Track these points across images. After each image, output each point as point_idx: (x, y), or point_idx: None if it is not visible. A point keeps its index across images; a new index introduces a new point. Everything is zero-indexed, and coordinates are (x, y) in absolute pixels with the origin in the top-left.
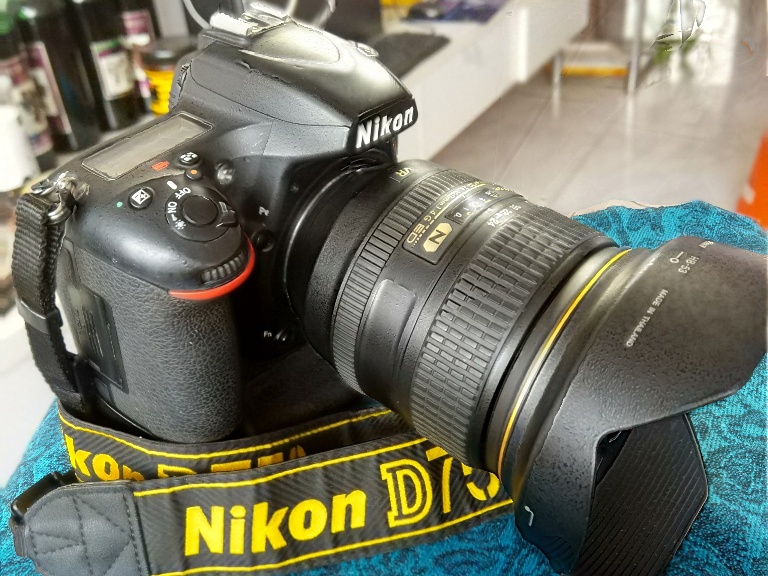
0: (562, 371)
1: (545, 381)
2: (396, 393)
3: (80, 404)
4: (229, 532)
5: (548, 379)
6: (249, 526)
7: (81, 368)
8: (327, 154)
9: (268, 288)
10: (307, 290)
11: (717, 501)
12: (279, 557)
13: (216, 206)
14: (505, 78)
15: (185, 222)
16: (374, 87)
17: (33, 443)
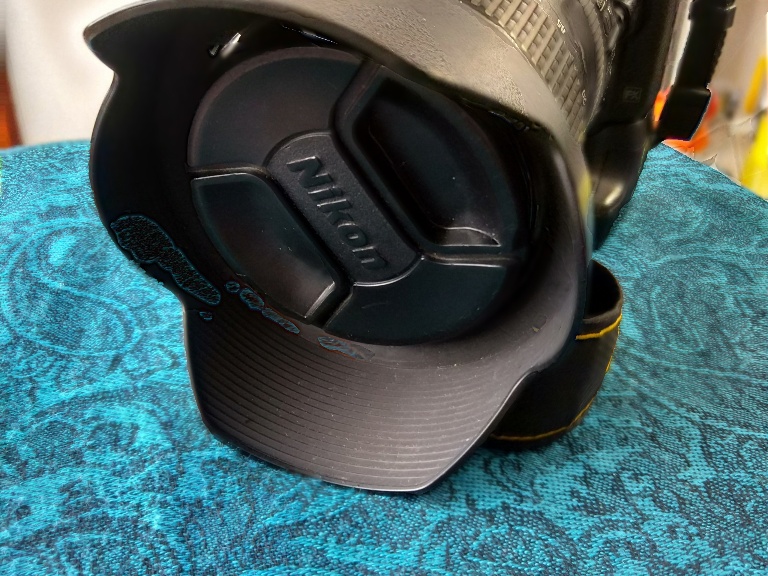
0: None
1: None
2: None
3: None
4: None
5: None
6: None
7: None
8: None
9: None
10: None
11: (431, 516)
12: None
13: None
14: None
15: None
16: None
17: None
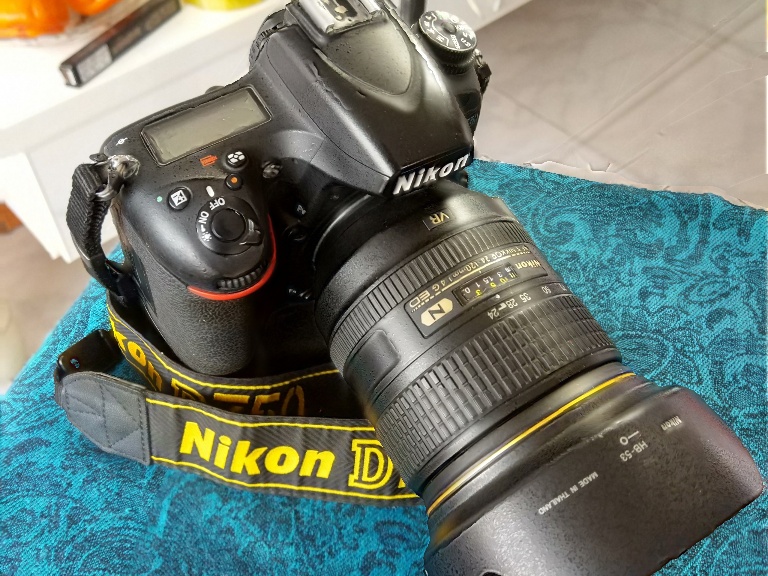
0: (486, 495)
1: (473, 490)
2: (368, 415)
3: (122, 302)
4: (216, 451)
5: (475, 490)
6: (232, 453)
7: (124, 281)
8: (365, 190)
9: (296, 264)
10: (320, 295)
11: None
12: (252, 480)
13: (245, 223)
14: (661, 5)
15: (212, 235)
16: (430, 135)
17: None
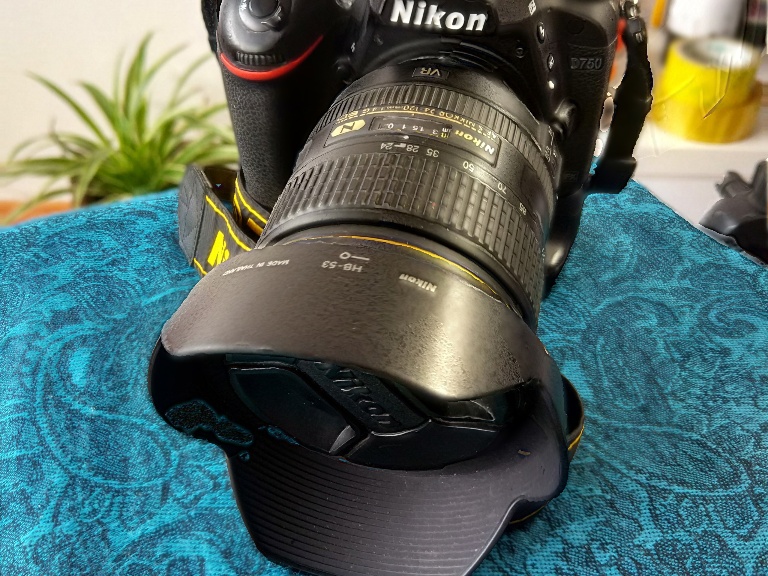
0: None
1: None
2: None
3: None
4: None
5: None
6: None
7: None
8: None
9: None
10: None
11: None
12: None
13: (276, 8)
14: None
15: (247, 6)
16: None
17: None
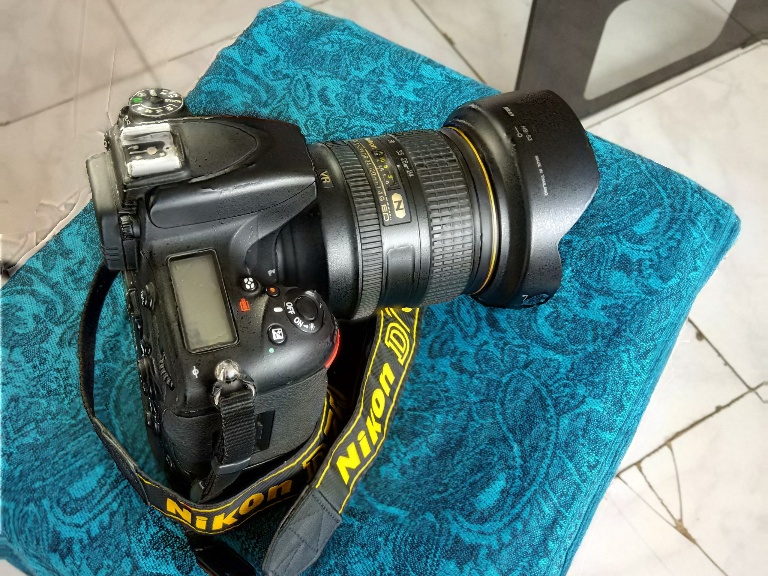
0: (517, 227)
1: (506, 237)
2: None
3: None
4: (360, 450)
5: (508, 235)
6: (368, 436)
7: None
8: None
9: None
10: (329, 293)
11: None
12: None
13: (307, 297)
14: None
15: (312, 323)
16: (293, 141)
17: (105, 568)
